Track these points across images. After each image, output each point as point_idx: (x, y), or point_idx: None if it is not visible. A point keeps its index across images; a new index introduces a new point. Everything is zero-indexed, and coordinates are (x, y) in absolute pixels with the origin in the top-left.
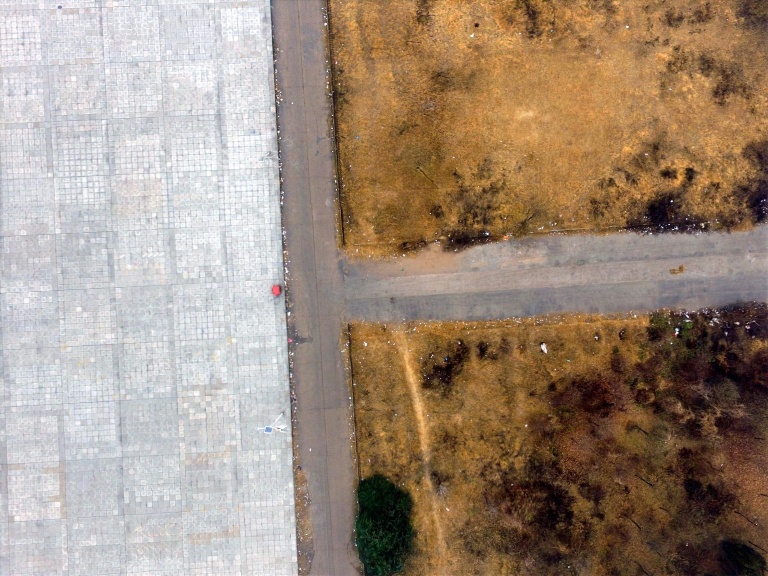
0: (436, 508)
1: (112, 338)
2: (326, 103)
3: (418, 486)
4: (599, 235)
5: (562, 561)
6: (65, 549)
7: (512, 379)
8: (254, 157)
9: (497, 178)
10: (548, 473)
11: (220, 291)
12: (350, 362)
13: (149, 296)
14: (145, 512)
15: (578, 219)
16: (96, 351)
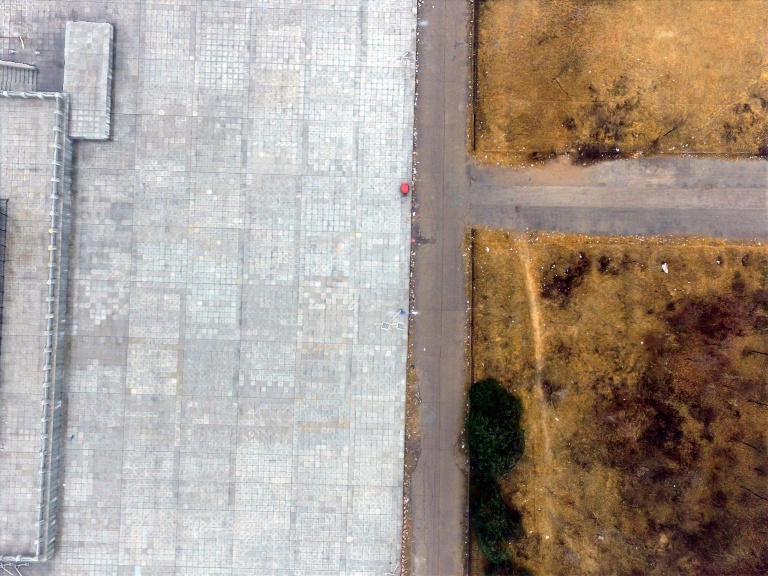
0: (545, 417)
1: (239, 223)
2: (466, 9)
3: (529, 394)
4: (729, 160)
5: (668, 480)
6: (178, 425)
7: (631, 296)
8: (392, 56)
9: (632, 96)
10: (660, 392)
11: (349, 185)
12: (471, 266)
13: (279, 185)
14: (259, 396)
15: (710, 142)
16: (223, 234)
